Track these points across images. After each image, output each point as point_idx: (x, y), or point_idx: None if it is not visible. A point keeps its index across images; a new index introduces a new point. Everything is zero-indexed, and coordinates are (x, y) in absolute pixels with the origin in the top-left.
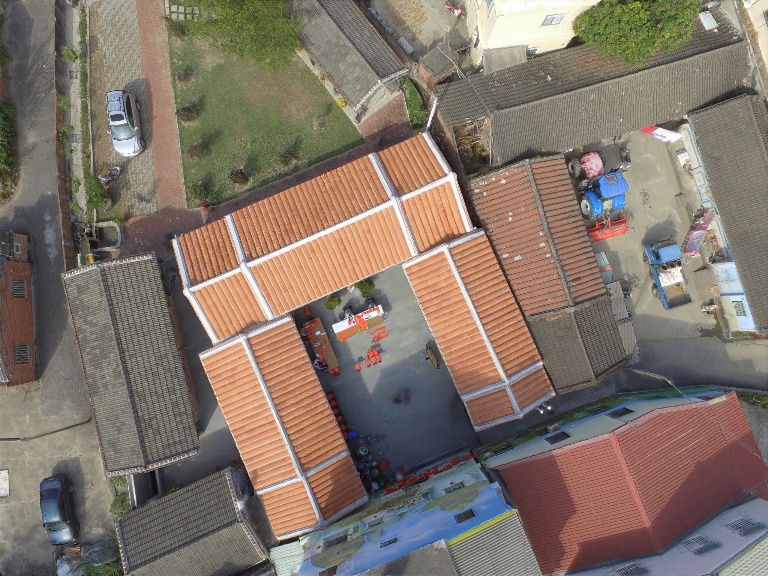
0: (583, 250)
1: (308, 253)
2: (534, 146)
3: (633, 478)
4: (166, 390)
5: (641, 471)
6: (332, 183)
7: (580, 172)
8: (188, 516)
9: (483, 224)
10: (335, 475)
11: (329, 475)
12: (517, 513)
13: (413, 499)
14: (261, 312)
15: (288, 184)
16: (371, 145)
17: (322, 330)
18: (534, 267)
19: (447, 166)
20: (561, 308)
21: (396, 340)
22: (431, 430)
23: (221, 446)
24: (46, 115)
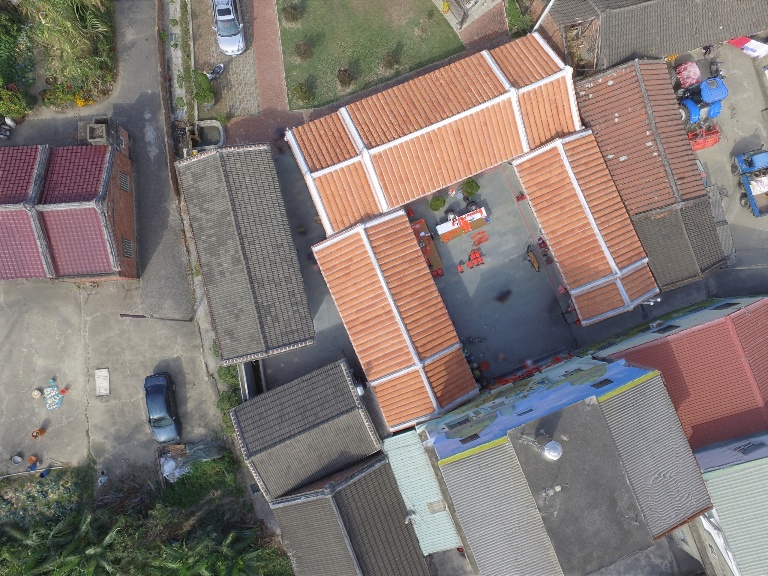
0: (685, 152)
1: (426, 144)
2: (638, 50)
3: (748, 360)
4: (283, 279)
5: (755, 354)
6: (446, 78)
7: (675, 82)
8: (305, 404)
9: (588, 126)
10: (449, 366)
11: (443, 366)
12: (661, 374)
13: (529, 387)
14: (376, 204)
15: (389, 88)
16: (471, 52)
17: (426, 231)
18: (640, 166)
19: (561, 62)
20: (668, 205)
21: (496, 244)
22: (530, 333)
23: (324, 347)
24: (145, 13)
